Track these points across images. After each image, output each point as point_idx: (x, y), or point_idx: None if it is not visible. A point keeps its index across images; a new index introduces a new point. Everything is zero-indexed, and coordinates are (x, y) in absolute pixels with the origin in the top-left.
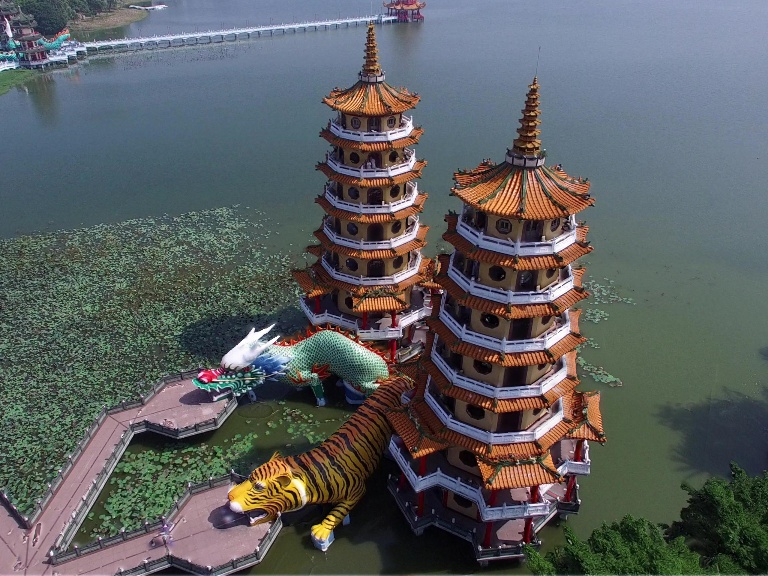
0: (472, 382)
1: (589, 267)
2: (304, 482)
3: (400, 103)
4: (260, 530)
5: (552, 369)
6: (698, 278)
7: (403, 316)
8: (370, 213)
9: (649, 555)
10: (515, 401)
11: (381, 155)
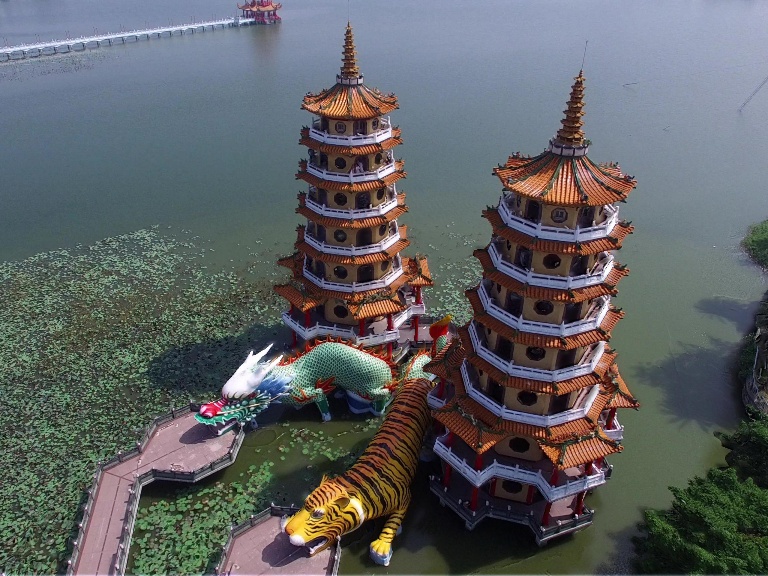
0: (529, 370)
1: None
2: (360, 500)
3: (383, 104)
4: (321, 559)
5: (588, 346)
6: (623, 247)
7: (395, 318)
8: (361, 218)
9: (745, 499)
10: (571, 381)
11: (368, 158)
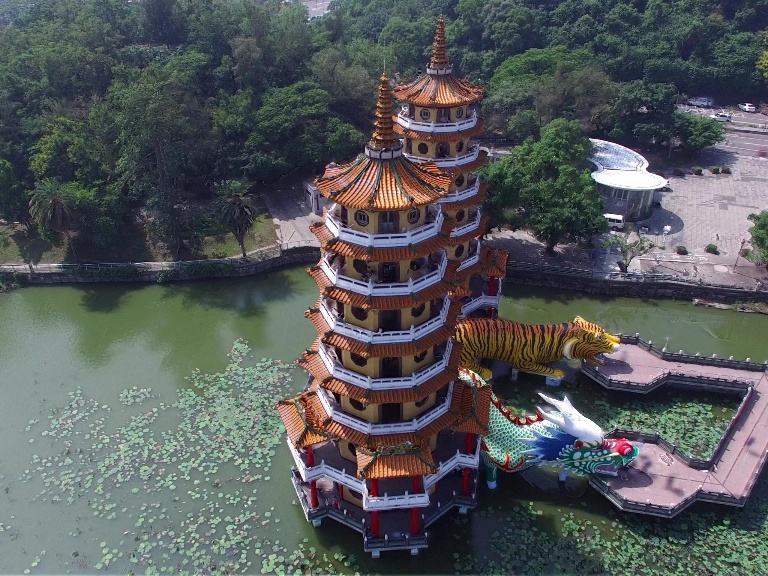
0: None
1: (0, 456)
2: None
3: None
4: None
5: None
6: None
7: None
8: None
9: None
10: None
11: None
